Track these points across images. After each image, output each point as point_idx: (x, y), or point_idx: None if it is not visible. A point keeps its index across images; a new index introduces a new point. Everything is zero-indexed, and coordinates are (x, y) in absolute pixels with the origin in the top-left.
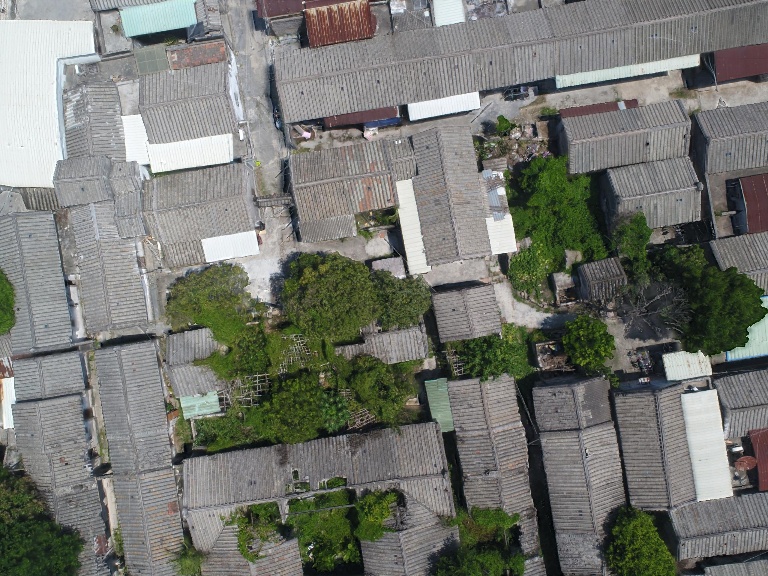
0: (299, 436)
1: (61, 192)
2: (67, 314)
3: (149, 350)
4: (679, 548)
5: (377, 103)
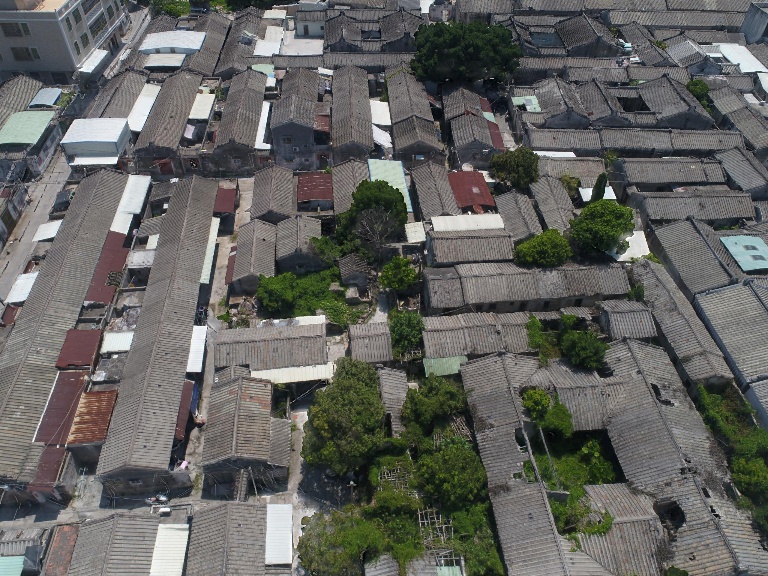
0: None
1: None
2: None
3: None
4: None
5: (177, 392)
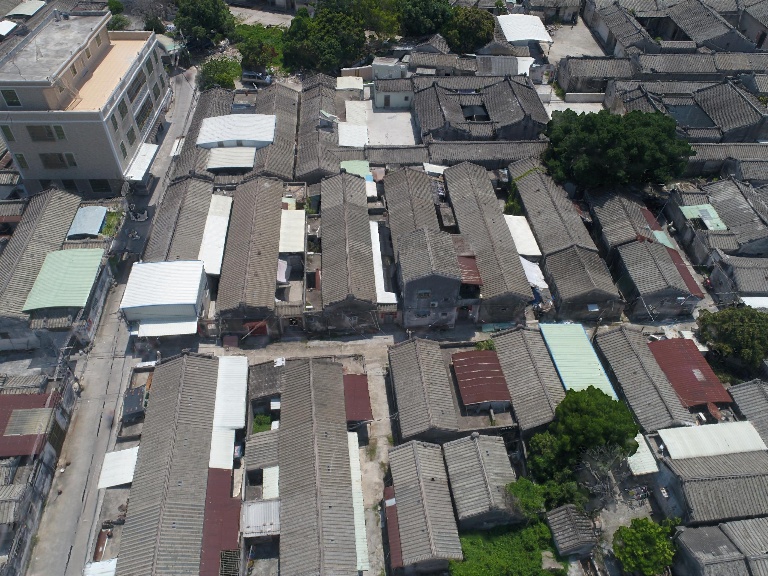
0: None
1: None
2: None
3: None
4: None
5: None
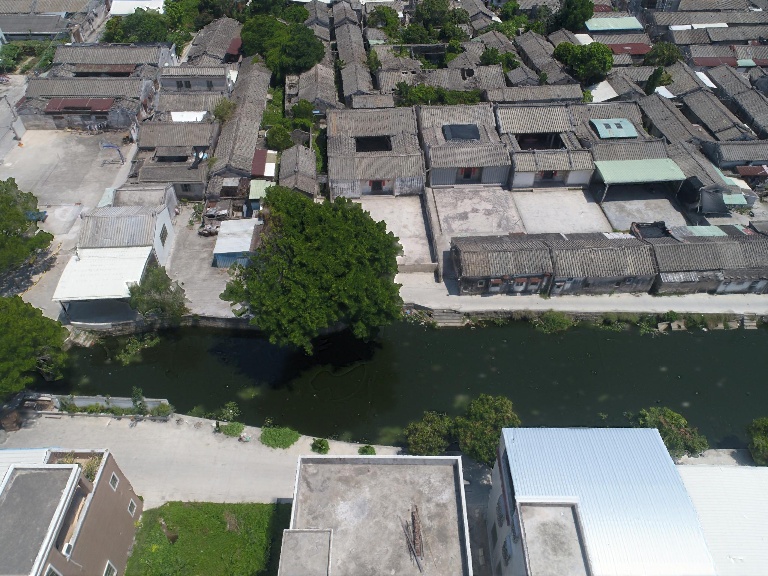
0: (420, 38)
1: None
2: (328, 19)
3: (358, 28)
4: None
5: None
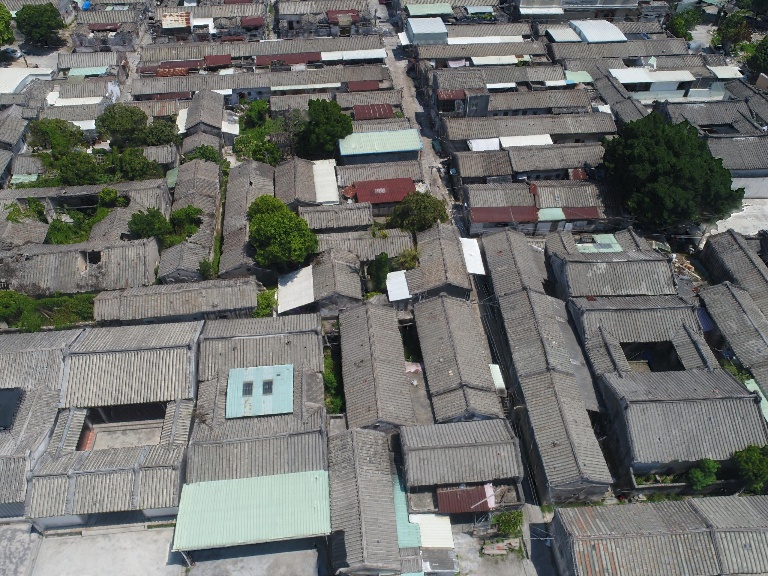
0: (77, 177)
1: (1, 98)
2: None
3: (8, 154)
4: (300, 217)
5: (180, 90)
